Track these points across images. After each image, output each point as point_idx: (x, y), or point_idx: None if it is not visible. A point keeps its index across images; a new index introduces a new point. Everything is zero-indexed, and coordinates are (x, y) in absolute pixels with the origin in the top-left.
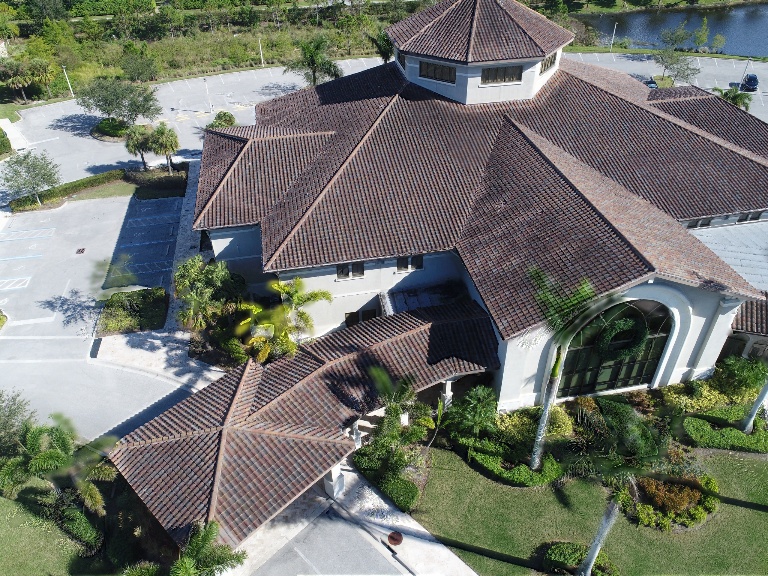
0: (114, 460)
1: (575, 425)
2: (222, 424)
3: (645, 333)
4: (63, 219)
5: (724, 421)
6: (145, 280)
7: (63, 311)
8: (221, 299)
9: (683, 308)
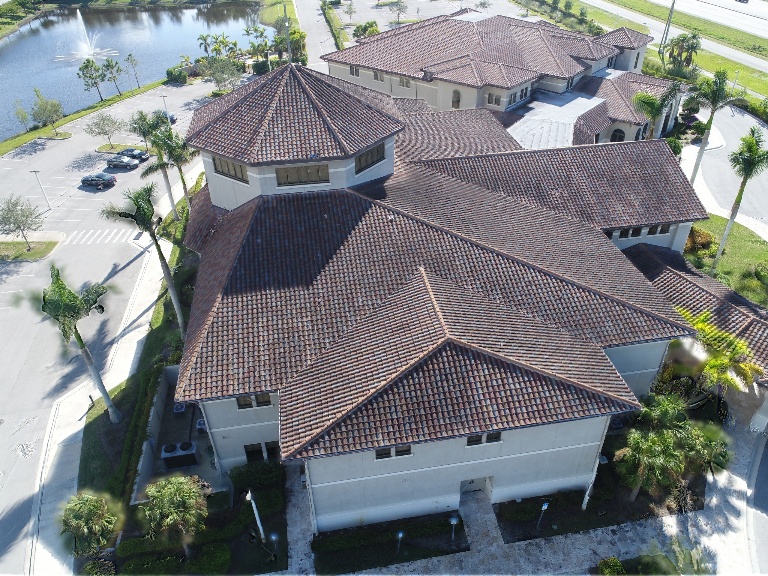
0: None
1: None
2: None
3: None
4: None
5: None
6: None
7: None
8: (685, 418)
9: None
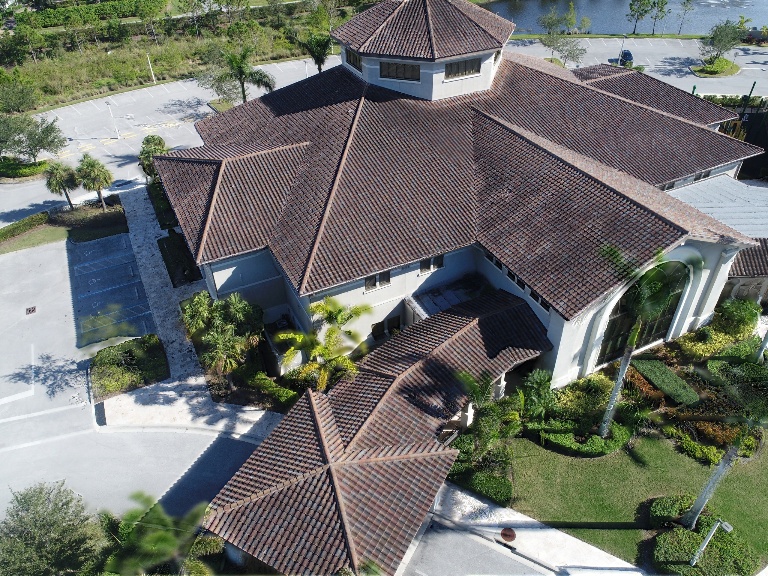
0: (213, 529)
1: (620, 389)
2: (325, 462)
3: (669, 292)
4: None
5: (738, 358)
6: (125, 329)
7: (41, 381)
8: (246, 333)
9: (697, 264)
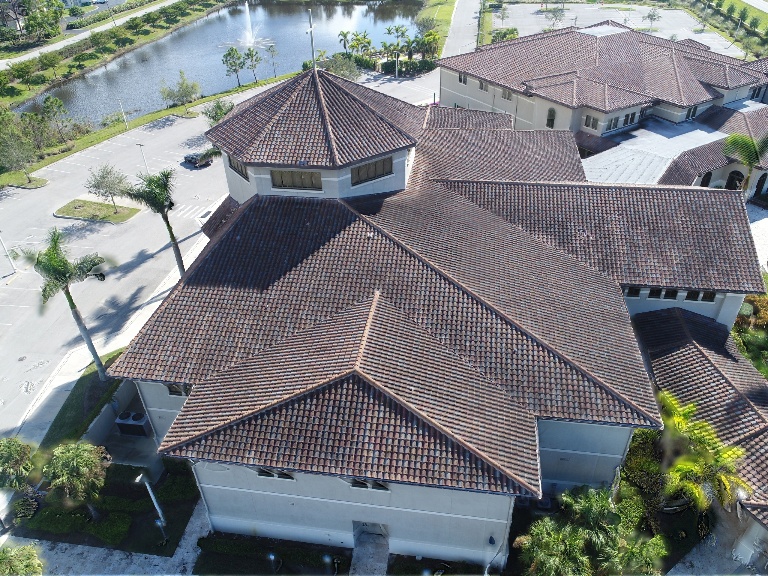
0: None
1: None
2: None
3: None
4: None
5: None
6: None
7: None
8: (620, 521)
9: None
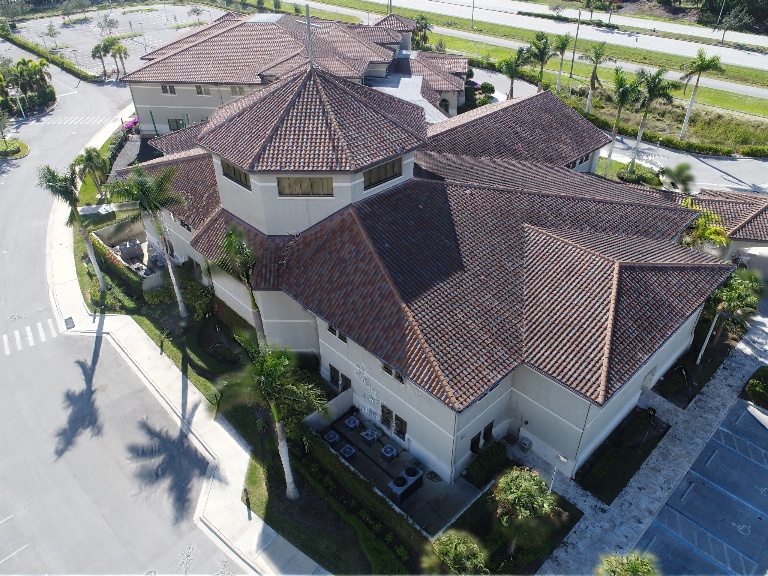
0: None
1: None
2: None
3: None
4: None
5: None
6: (761, 434)
7: None
8: None
9: None
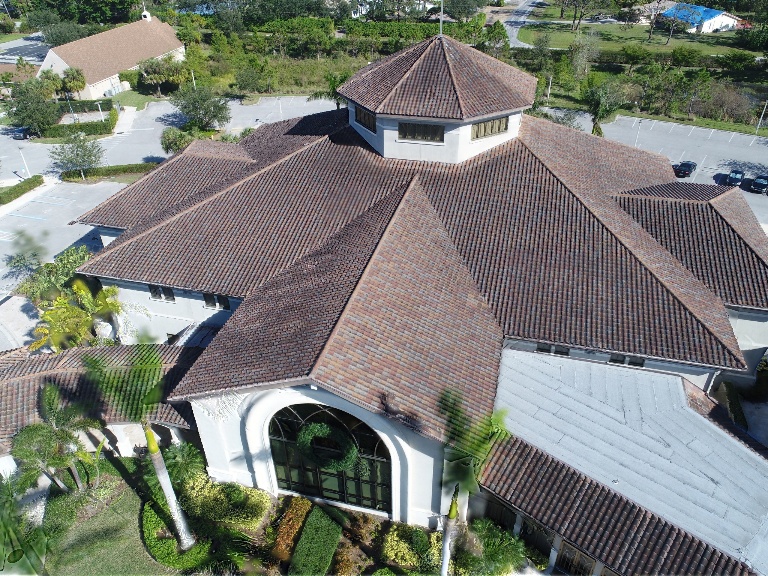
0: None
1: (270, 524)
2: None
3: (347, 449)
4: (87, 194)
5: None
6: None
7: (12, 267)
8: (68, 288)
9: (391, 435)
